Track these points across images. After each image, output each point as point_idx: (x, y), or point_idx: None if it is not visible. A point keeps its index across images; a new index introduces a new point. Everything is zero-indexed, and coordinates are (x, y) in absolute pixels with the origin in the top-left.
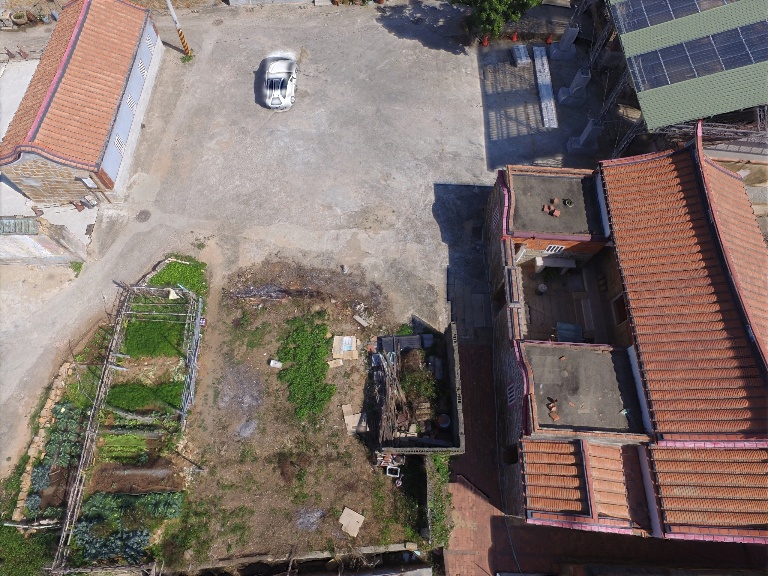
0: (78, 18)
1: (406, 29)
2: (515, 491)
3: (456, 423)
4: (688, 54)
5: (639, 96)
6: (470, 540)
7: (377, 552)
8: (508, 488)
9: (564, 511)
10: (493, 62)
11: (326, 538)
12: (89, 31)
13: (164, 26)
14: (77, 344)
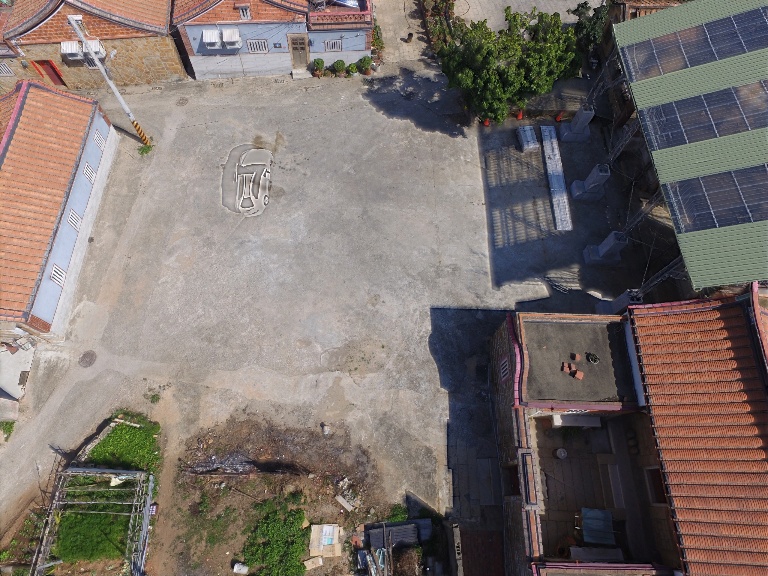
0: (8, 123)
1: (396, 106)
2: None
3: None
4: (739, 187)
5: (679, 239)
6: None
7: None
8: None
9: None
10: (496, 146)
11: None
12: (22, 138)
13: (120, 108)
14: (2, 537)
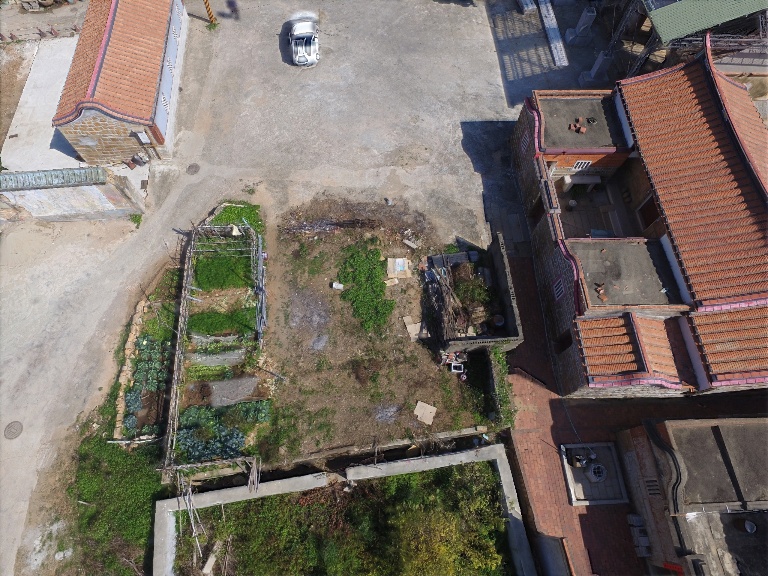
0: None
1: None
2: (571, 370)
3: (512, 318)
4: None
5: (651, 15)
6: (533, 420)
7: (452, 436)
8: (563, 373)
9: (622, 372)
10: (501, 11)
11: (404, 428)
12: None
13: None
14: (148, 285)
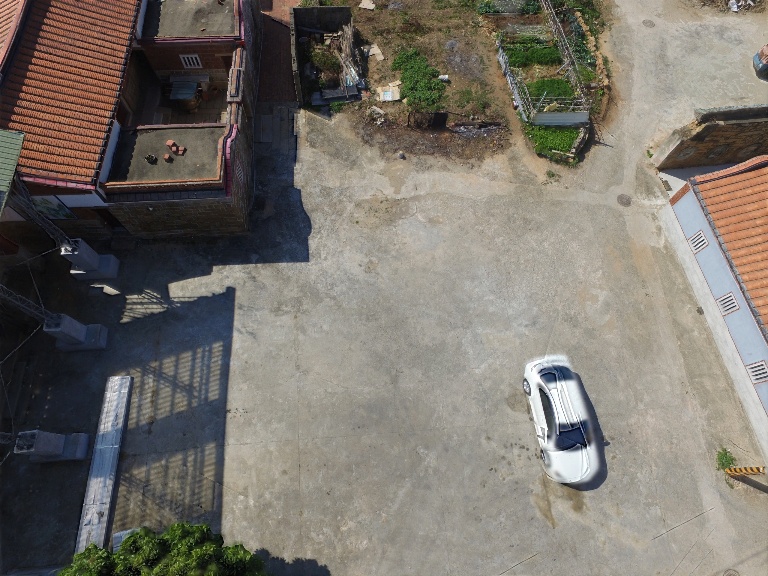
0: None
1: None
2: None
3: None
4: None
5: (8, 185)
6: (287, 2)
7: None
8: None
9: None
10: None
11: None
12: None
13: None
14: None
